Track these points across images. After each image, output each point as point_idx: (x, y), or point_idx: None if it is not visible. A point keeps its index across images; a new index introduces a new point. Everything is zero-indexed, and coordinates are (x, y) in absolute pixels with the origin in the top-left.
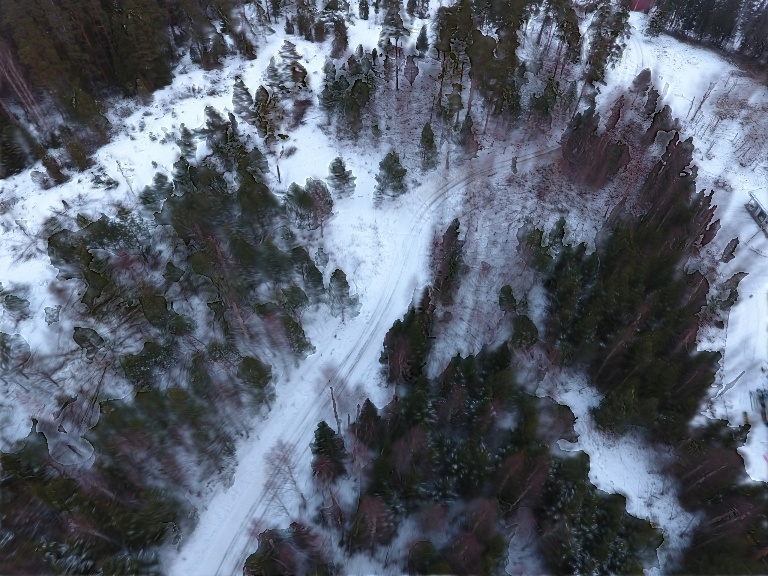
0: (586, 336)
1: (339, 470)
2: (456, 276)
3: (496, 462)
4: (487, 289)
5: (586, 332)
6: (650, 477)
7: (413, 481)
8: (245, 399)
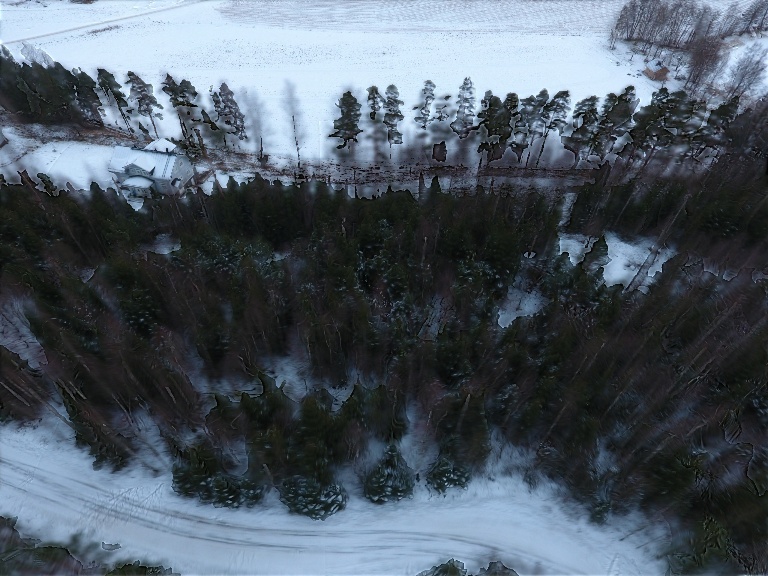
0: (47, 245)
1: (125, 439)
2: None
3: (144, 294)
4: None
5: (43, 242)
6: (176, 249)
7: (147, 346)
8: (2, 547)
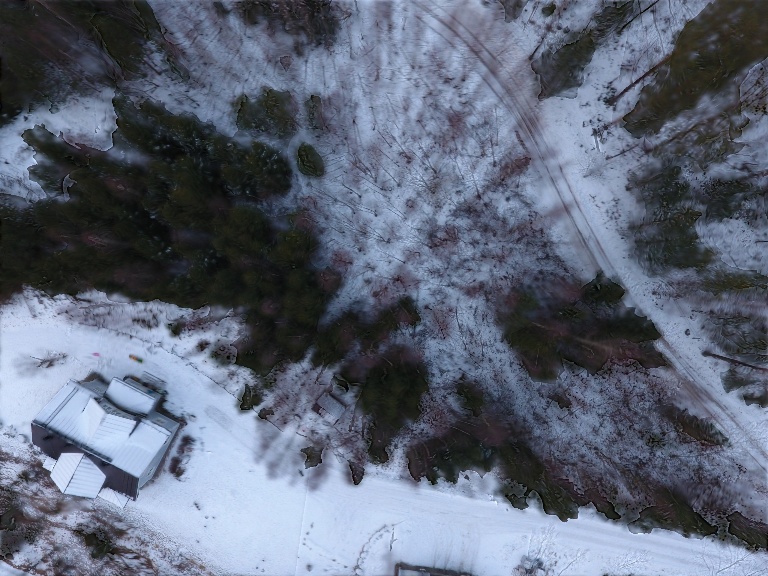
0: None
1: None
2: (276, 24)
3: None
4: (270, 75)
5: None
6: (45, 196)
7: None
8: None
